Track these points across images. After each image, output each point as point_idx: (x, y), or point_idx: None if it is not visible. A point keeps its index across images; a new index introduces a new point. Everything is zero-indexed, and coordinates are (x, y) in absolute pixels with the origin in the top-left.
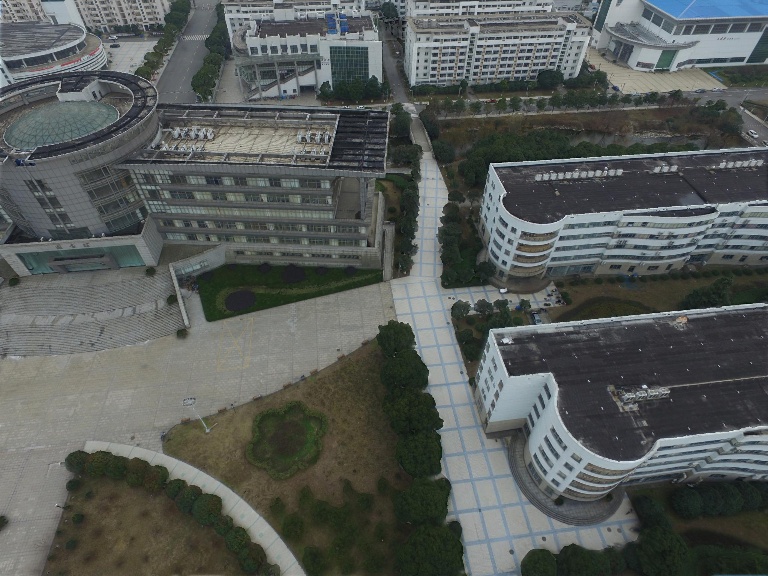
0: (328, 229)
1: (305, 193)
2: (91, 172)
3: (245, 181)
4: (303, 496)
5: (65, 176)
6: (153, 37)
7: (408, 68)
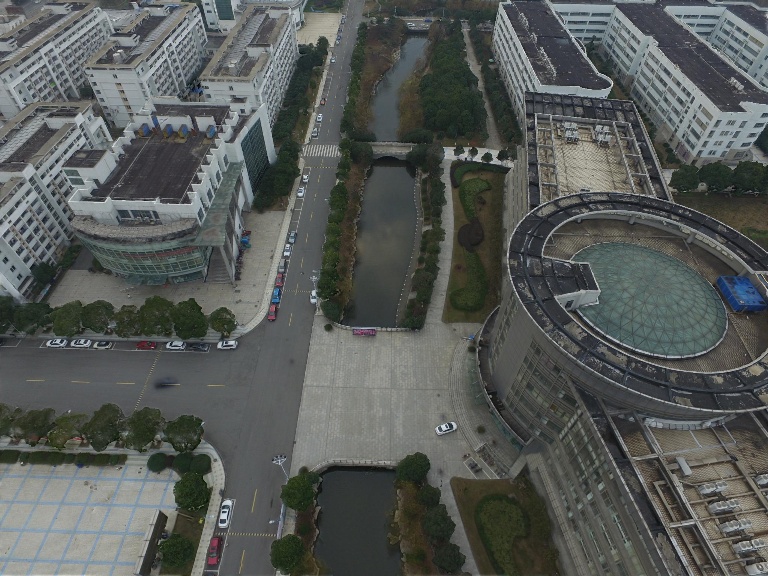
0: None
1: None
2: None
3: None
4: None
5: None
6: None
7: None
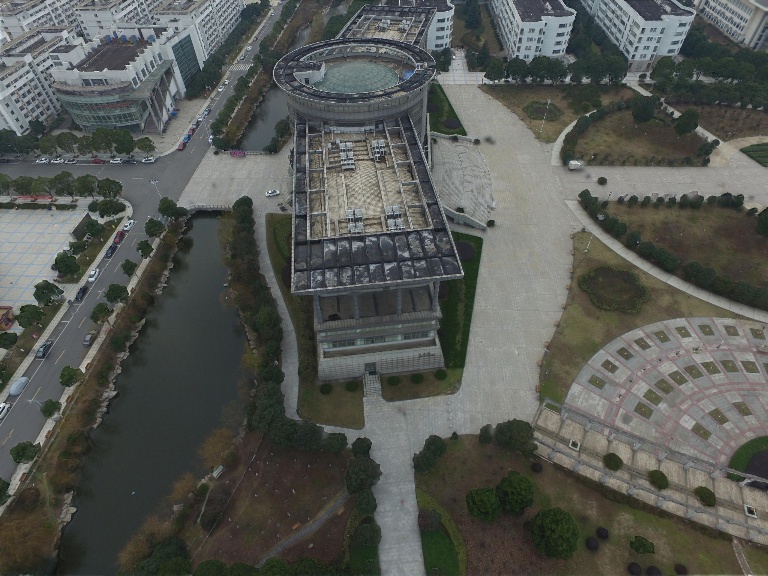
0: None
1: None
2: None
3: None
4: (572, 104)
5: None
6: None
7: None
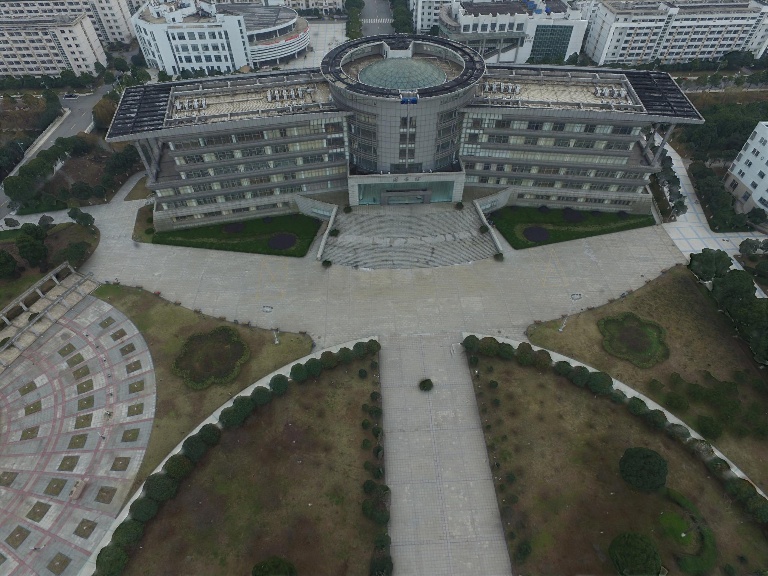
0: (615, 175)
1: (614, 139)
2: (447, 113)
3: (563, 127)
4: (675, 379)
5: (431, 115)
6: (333, 20)
7: (594, 48)
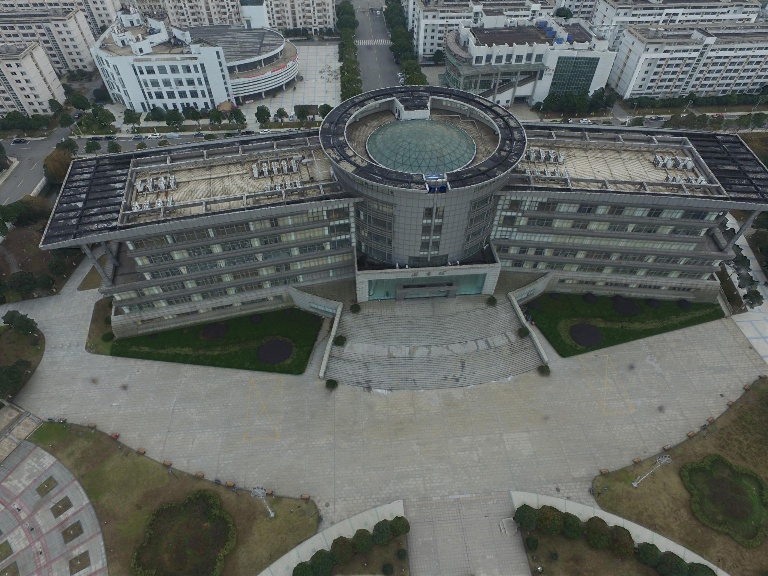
0: (678, 261)
1: (683, 224)
2: (482, 199)
3: (622, 210)
4: None
5: (463, 204)
6: (324, 41)
7: (617, 79)
